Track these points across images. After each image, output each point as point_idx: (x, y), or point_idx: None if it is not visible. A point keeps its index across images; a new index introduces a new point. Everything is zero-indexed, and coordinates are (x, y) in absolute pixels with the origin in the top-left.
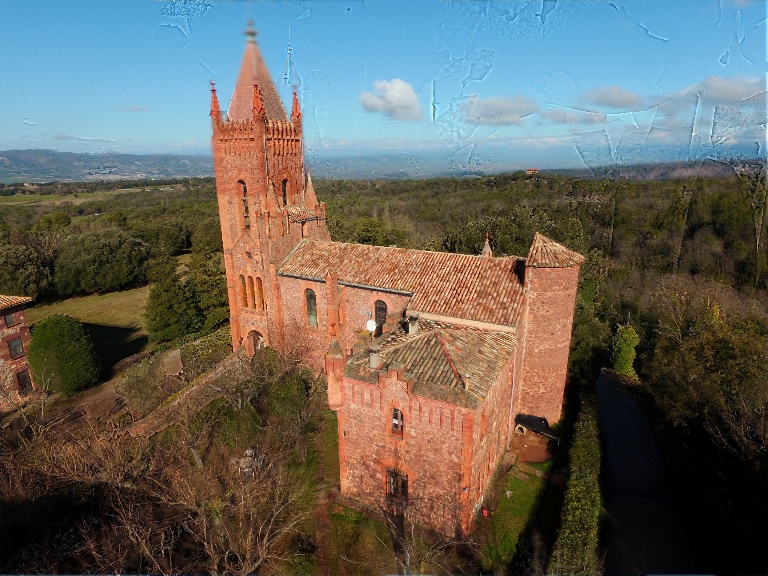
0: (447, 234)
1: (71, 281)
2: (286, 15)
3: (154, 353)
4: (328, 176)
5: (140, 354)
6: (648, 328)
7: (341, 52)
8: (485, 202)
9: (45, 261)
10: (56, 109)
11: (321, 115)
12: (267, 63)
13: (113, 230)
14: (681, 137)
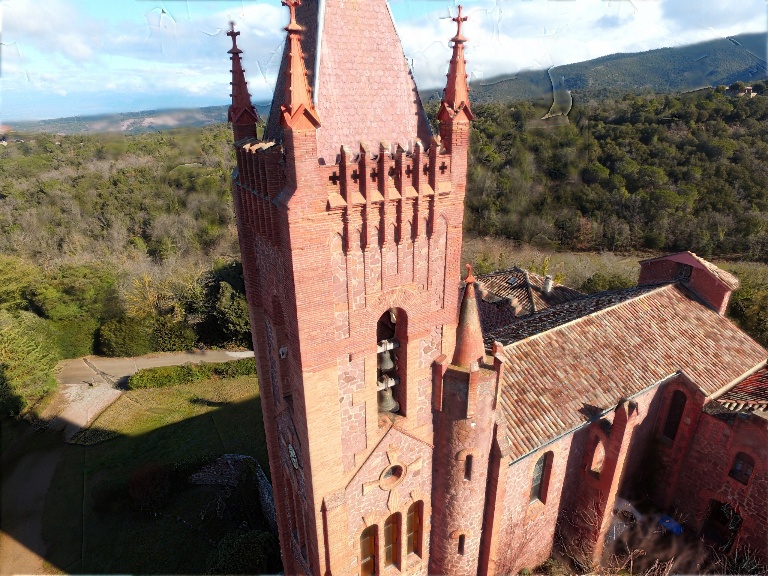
0: None
1: None
2: None
3: None
4: None
5: None
6: None
7: (759, 19)
8: (210, 198)
9: None
10: None
11: None
12: None
13: None
14: None
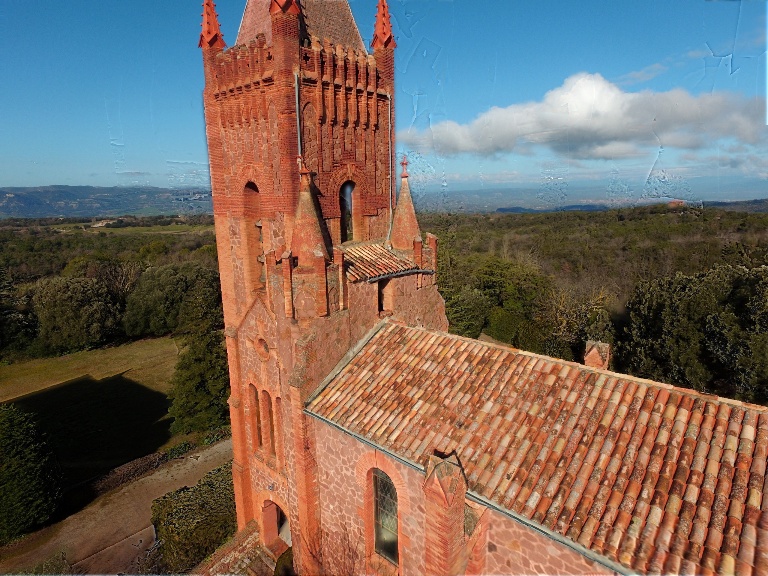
0: (636, 290)
1: (140, 321)
2: None
3: (167, 457)
4: (442, 201)
5: (143, 460)
6: None
7: None
8: (681, 238)
9: (118, 296)
10: (151, 131)
11: (437, 120)
12: None
13: (193, 263)
14: None
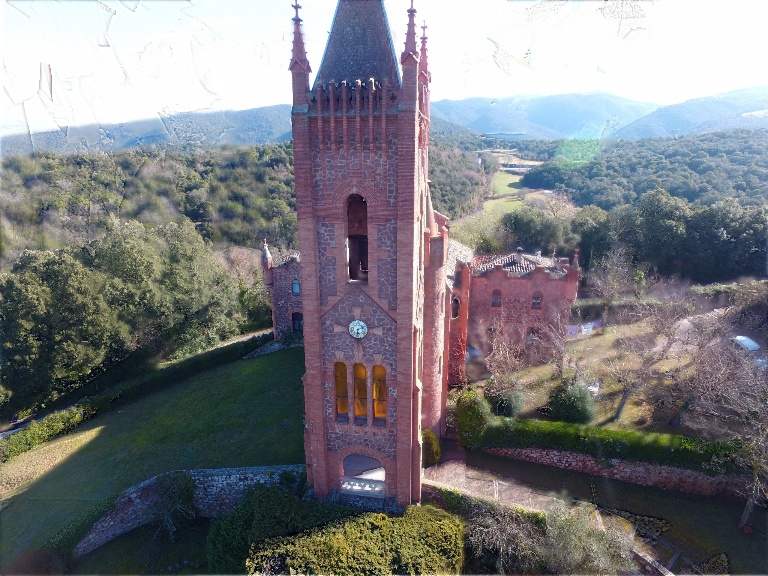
0: None
1: None
2: (539, 27)
3: None
4: None
5: None
6: (237, 299)
7: None
8: None
9: None
10: None
11: None
12: (537, 61)
13: None
14: (19, 136)
